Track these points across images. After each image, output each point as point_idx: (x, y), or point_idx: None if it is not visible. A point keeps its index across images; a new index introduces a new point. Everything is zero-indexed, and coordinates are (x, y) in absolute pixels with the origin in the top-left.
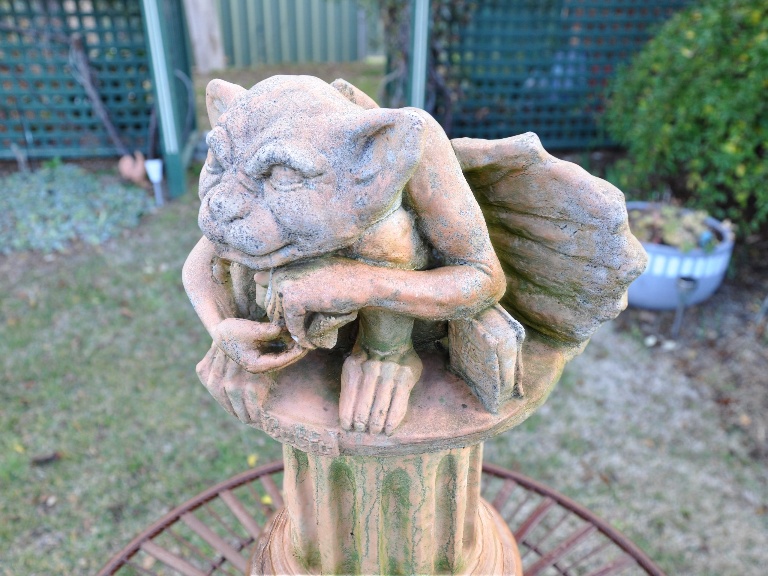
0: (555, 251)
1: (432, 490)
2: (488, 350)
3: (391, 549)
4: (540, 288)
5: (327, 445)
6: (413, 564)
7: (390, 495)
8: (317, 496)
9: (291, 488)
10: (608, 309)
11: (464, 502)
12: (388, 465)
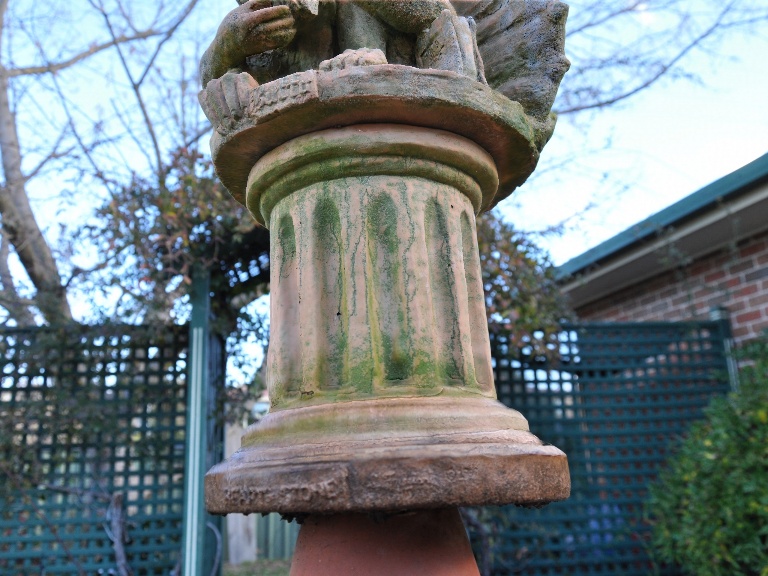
0: (499, 33)
1: (421, 230)
2: (444, 19)
3: (383, 322)
4: (498, 79)
5: (306, 80)
6: (410, 331)
7: (378, 245)
8: (300, 259)
9: (274, 294)
10: (554, 61)
11: (464, 284)
12: (372, 187)
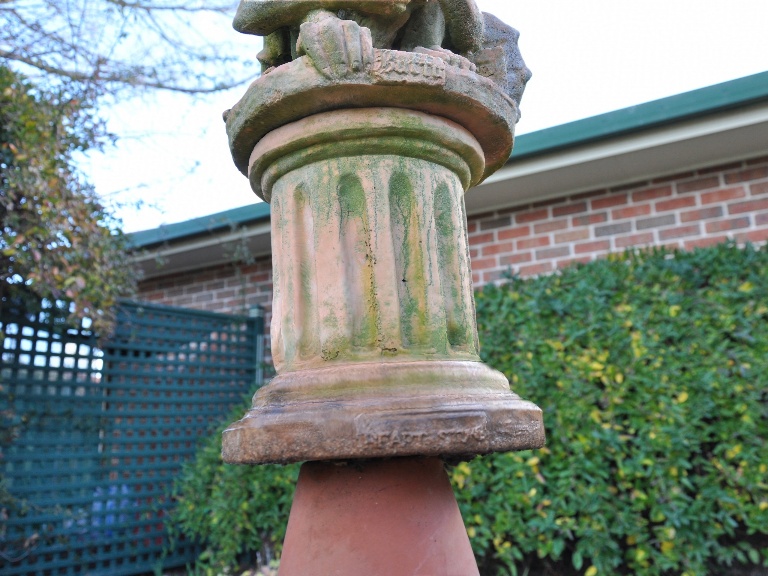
0: None
1: (462, 222)
2: (499, 54)
3: None
4: None
5: (440, 66)
6: (463, 306)
7: None
8: (376, 222)
9: (330, 249)
10: None
11: None
12: (438, 174)
